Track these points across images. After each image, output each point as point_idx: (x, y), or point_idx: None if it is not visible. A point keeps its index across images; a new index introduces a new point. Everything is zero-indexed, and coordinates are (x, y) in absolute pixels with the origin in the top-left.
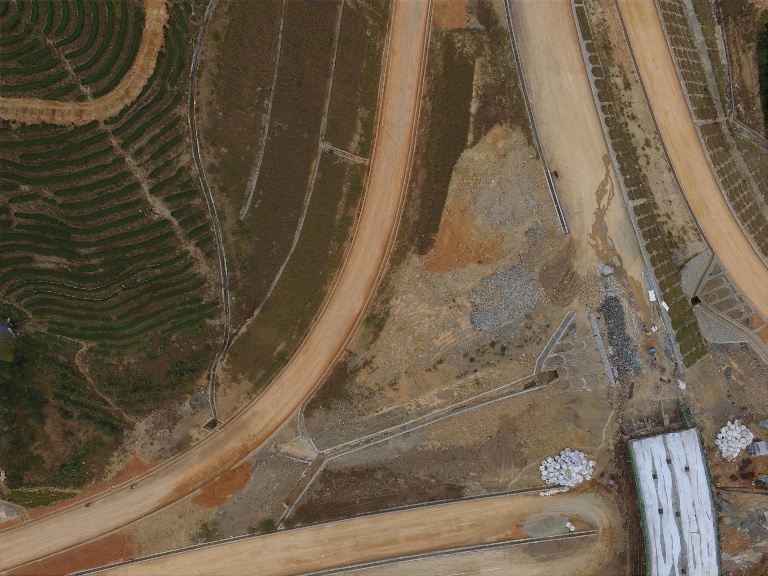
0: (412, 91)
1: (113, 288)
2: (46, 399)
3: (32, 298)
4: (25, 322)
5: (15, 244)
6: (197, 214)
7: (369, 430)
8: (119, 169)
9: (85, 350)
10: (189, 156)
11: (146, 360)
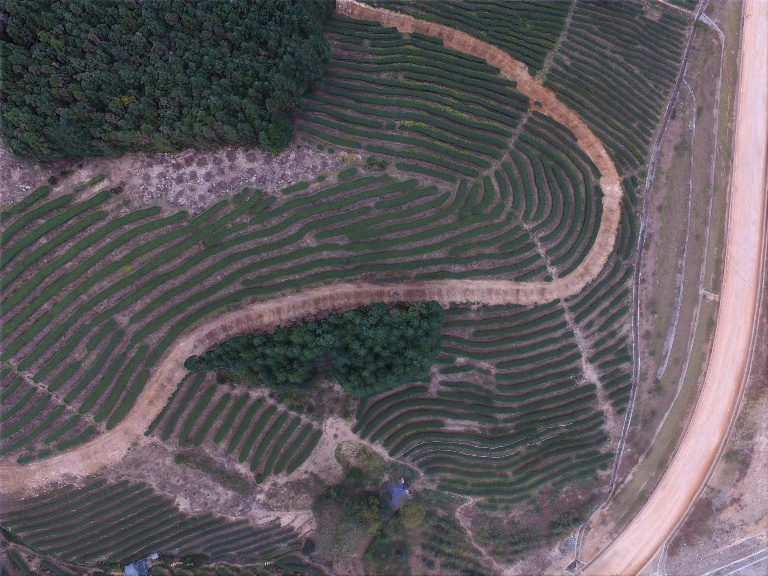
0: (756, 227)
1: (517, 447)
2: (411, 550)
3: (427, 457)
4: (414, 480)
5: (426, 408)
6: (625, 378)
7: (722, 562)
8: (564, 341)
9: (471, 505)
10: (629, 325)
11: (533, 512)
